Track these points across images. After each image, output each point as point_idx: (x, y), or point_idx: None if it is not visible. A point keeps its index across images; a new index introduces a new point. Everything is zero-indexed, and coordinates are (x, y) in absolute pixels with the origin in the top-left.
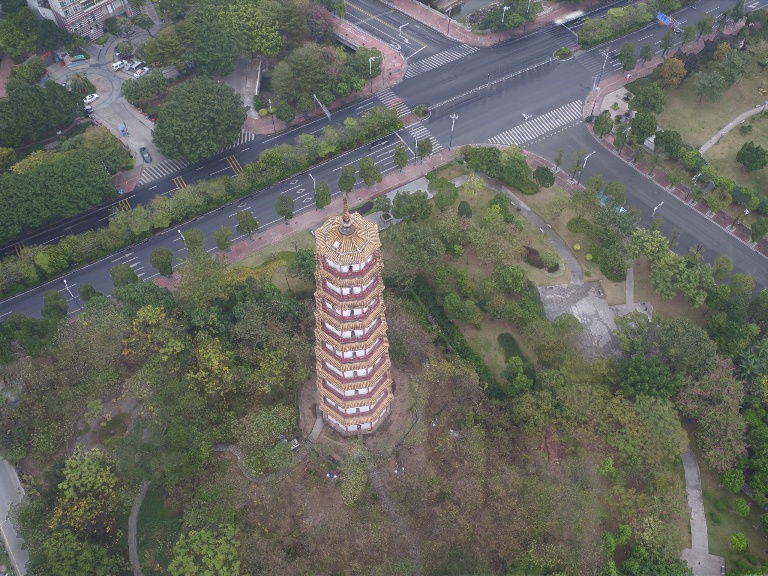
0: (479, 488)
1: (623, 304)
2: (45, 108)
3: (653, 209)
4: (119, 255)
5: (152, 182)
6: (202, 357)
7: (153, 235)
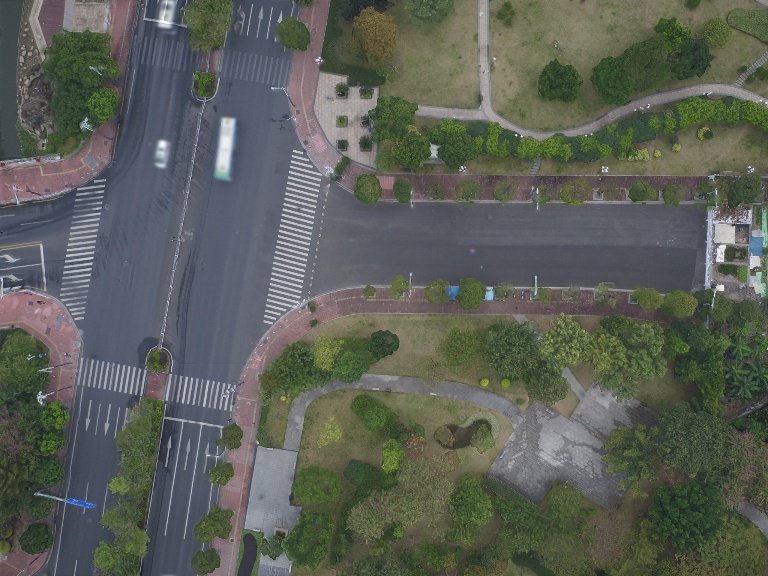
0: None
1: (579, 404)
2: None
3: (507, 246)
4: None
5: None
6: None
7: None
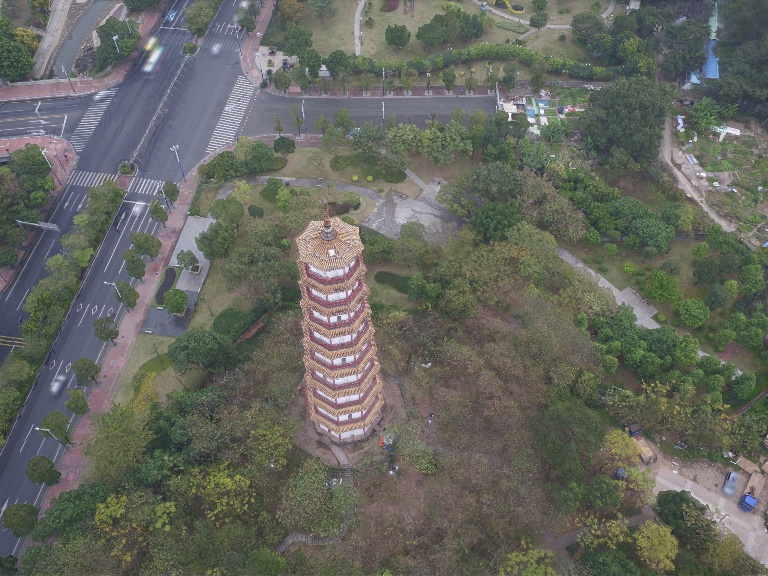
0: (493, 374)
1: (422, 191)
2: None
3: (371, 116)
4: None
5: None
6: (207, 490)
7: None
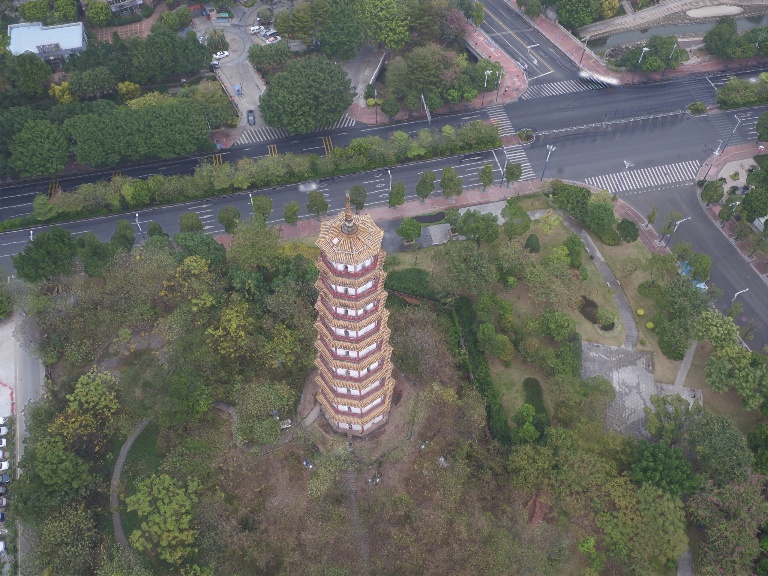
0: (443, 523)
1: (671, 384)
2: (175, 55)
3: (740, 294)
4: (197, 204)
5: (249, 144)
6: (225, 317)
7: (232, 193)
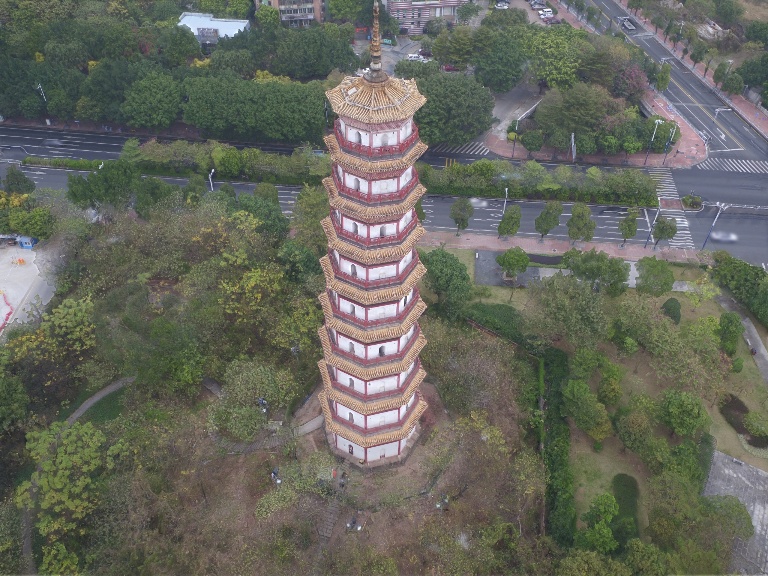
0: None
1: None
2: (321, 54)
3: None
4: (287, 189)
5: None
6: None
7: None
